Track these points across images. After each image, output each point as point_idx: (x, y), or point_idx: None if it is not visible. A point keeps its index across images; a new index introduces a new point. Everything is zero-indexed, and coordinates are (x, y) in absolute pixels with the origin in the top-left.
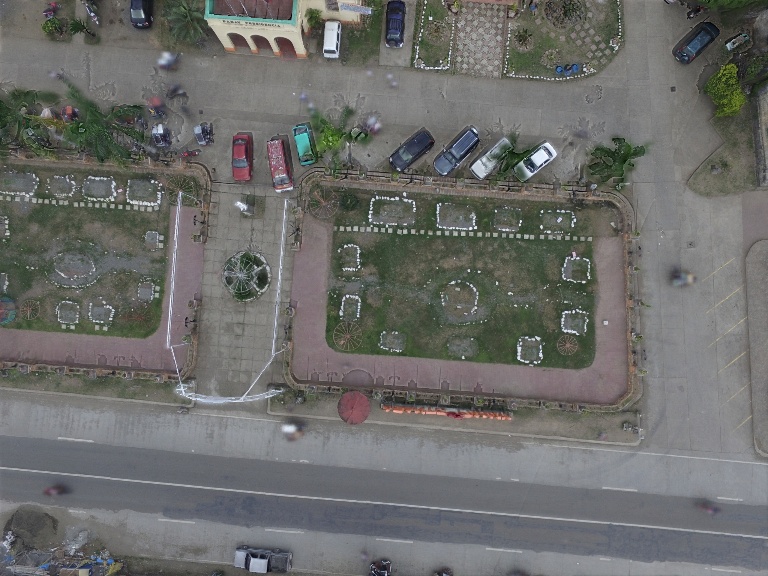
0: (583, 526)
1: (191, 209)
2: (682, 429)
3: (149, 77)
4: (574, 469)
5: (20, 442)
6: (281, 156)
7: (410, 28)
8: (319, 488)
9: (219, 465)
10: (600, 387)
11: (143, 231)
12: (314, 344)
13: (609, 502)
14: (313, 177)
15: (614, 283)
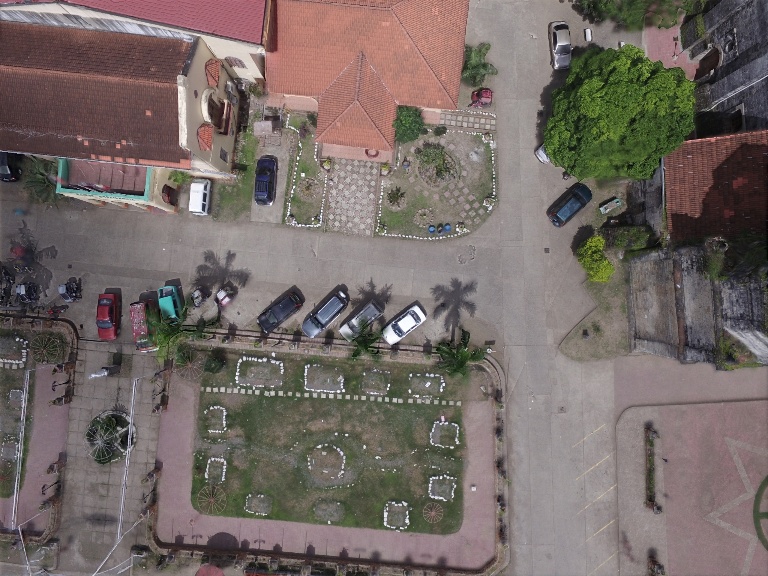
0: None
1: None
2: None
3: (17, 230)
4: None
5: None
6: (143, 321)
7: (282, 184)
8: None
9: None
10: (467, 553)
11: (8, 389)
12: (179, 506)
13: None
14: (180, 336)
15: (483, 448)
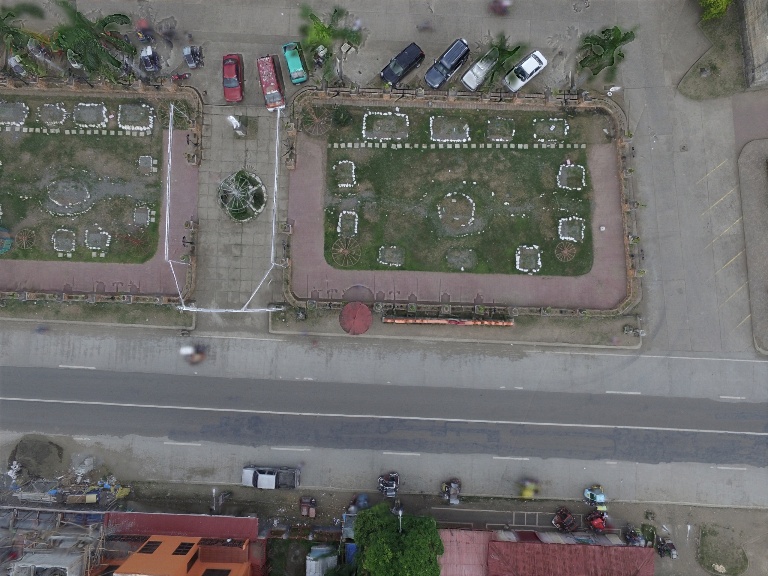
0: (588, 431)
1: (184, 132)
2: (682, 331)
3: (136, 2)
4: (577, 375)
5: (21, 372)
6: (272, 72)
7: None
8: (324, 405)
9: (223, 386)
10: (599, 293)
11: (136, 156)
12: (313, 262)
13: (613, 406)
14: (305, 95)
15: (609, 189)
